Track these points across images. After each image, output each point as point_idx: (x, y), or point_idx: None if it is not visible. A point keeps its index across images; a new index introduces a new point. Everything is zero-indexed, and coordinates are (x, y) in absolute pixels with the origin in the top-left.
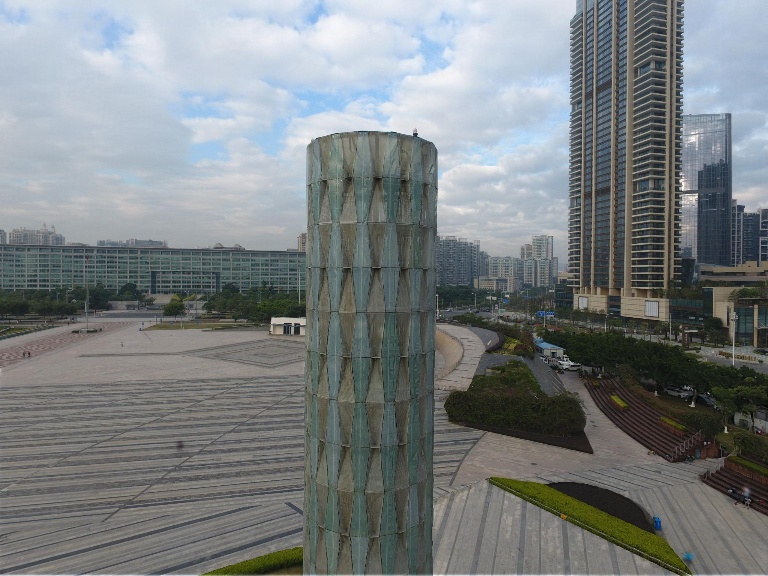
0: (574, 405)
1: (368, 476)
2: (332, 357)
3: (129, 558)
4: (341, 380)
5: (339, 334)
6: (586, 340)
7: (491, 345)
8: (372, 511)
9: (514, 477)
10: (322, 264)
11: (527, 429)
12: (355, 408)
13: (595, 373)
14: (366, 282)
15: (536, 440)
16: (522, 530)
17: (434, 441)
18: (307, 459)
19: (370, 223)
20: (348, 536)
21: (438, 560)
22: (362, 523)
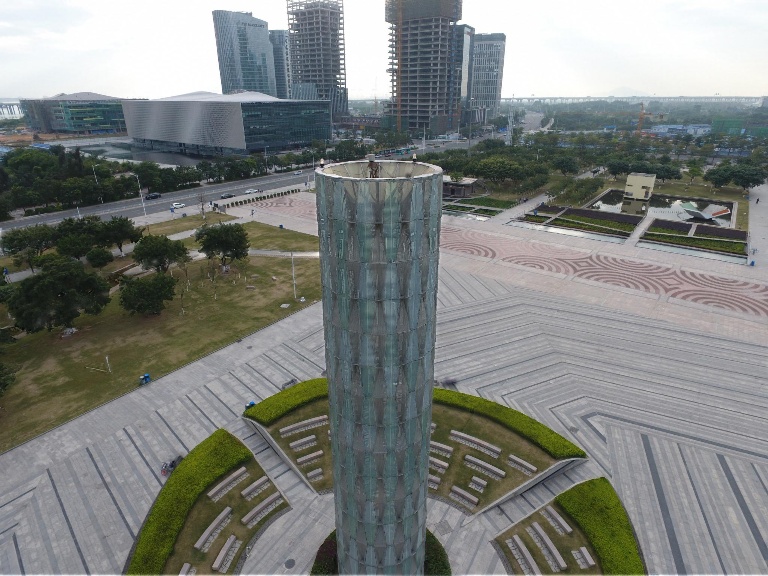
0: None
1: None
2: None
3: (731, 575)
4: None
5: None
6: None
7: None
8: None
9: None
10: None
11: None
12: None
13: None
14: None
15: None
16: None
17: None
18: None
19: None
20: None
21: None
22: None
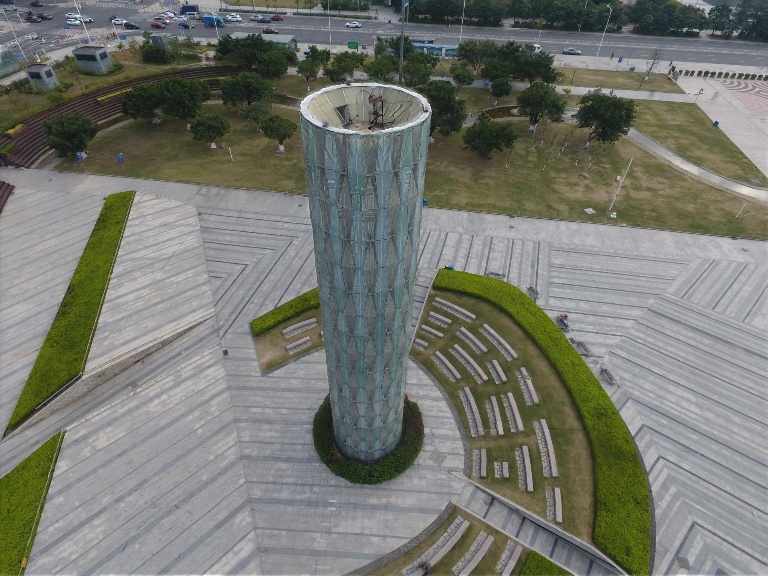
0: None
1: None
2: None
3: None
4: None
5: None
6: None
7: None
8: None
9: None
10: None
11: None
12: None
13: None
14: None
15: None
16: (86, 575)
17: None
18: None
19: None
20: None
21: None
22: None
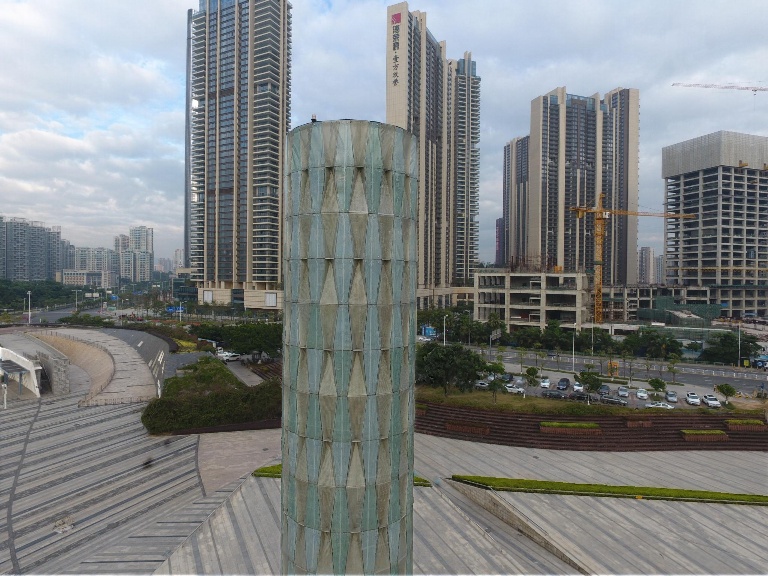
0: (278, 388)
1: (399, 461)
2: (368, 352)
3: None
4: (379, 374)
5: (377, 327)
6: (249, 330)
7: (146, 346)
8: (400, 493)
9: (258, 466)
10: (355, 255)
11: (239, 421)
12: (392, 398)
13: (255, 360)
14: (399, 274)
15: (252, 428)
16: None
17: (149, 460)
18: (320, 471)
19: (402, 218)
20: (387, 526)
21: (257, 565)
22: (394, 508)
